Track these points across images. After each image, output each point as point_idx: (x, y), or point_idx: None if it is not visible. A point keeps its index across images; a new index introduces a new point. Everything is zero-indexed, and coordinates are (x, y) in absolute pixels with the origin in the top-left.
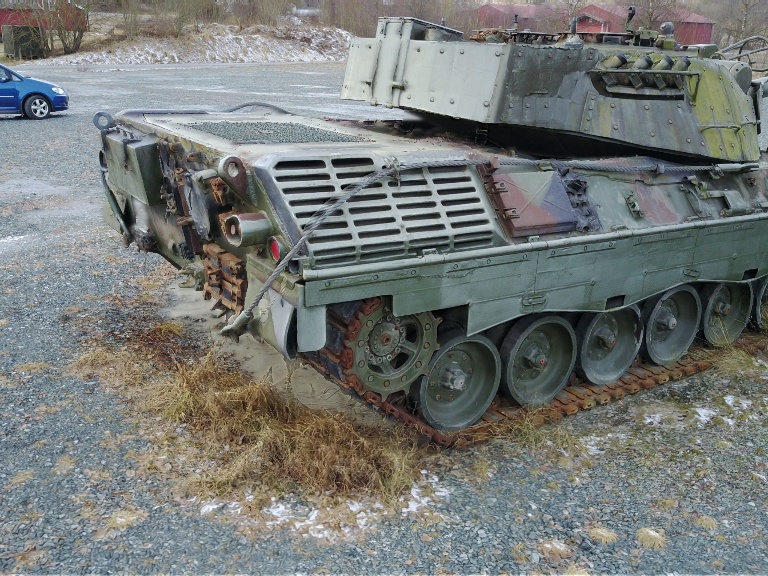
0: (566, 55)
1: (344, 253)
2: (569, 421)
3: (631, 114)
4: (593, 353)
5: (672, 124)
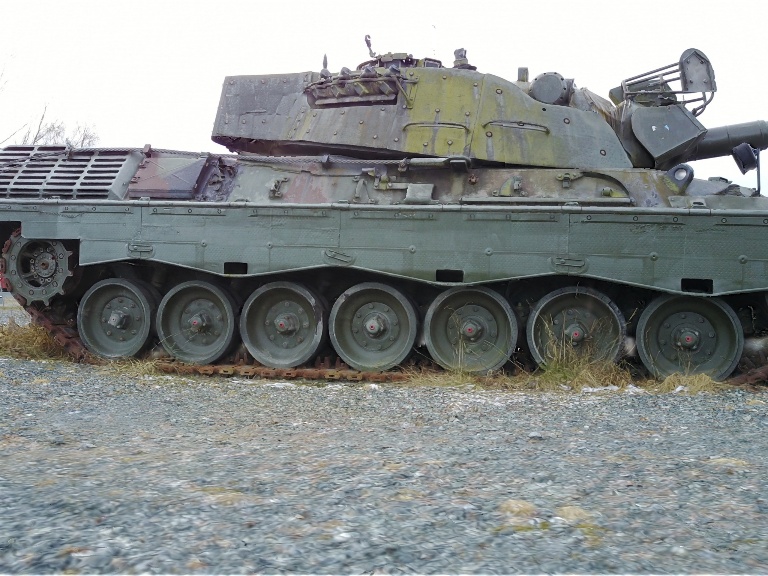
0: (282, 80)
1: (0, 192)
2: (194, 376)
3: (326, 119)
4: (279, 339)
5: (363, 124)
